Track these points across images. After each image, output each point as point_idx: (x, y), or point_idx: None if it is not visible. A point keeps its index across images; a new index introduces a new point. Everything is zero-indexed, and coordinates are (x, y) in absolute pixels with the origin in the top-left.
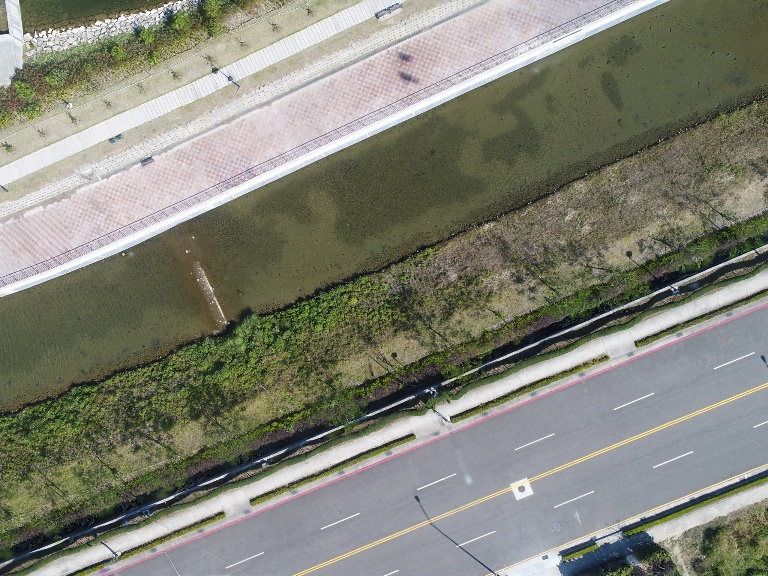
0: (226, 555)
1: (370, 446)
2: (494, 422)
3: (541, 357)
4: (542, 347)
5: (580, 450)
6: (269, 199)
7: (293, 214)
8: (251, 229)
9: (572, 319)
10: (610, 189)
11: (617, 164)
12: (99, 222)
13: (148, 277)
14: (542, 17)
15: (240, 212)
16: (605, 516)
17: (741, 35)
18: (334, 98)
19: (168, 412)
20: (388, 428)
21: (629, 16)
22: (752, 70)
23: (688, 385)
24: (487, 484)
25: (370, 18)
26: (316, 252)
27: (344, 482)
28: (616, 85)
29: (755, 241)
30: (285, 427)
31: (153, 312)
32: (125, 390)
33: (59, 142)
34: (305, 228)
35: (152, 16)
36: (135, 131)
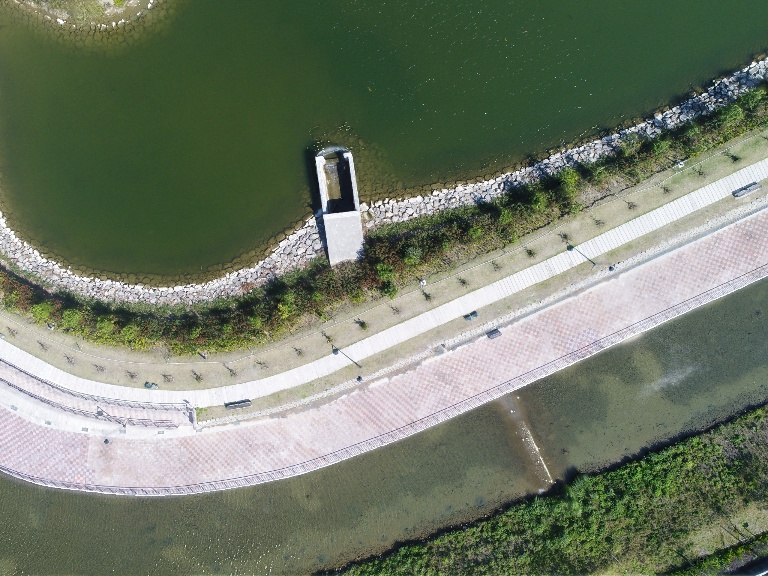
0: None
1: None
2: None
3: None
4: None
5: None
6: (593, 359)
7: (618, 374)
8: (575, 389)
9: None
10: None
11: None
12: (445, 393)
13: (471, 436)
14: None
15: (564, 372)
16: None
17: None
18: (682, 271)
19: None
20: None
21: None
22: None
23: None
24: None
25: (727, 196)
26: (641, 411)
27: None
28: None
29: None
30: None
31: (476, 471)
32: (458, 552)
33: (413, 319)
34: (630, 388)
35: (492, 187)
36: (490, 308)
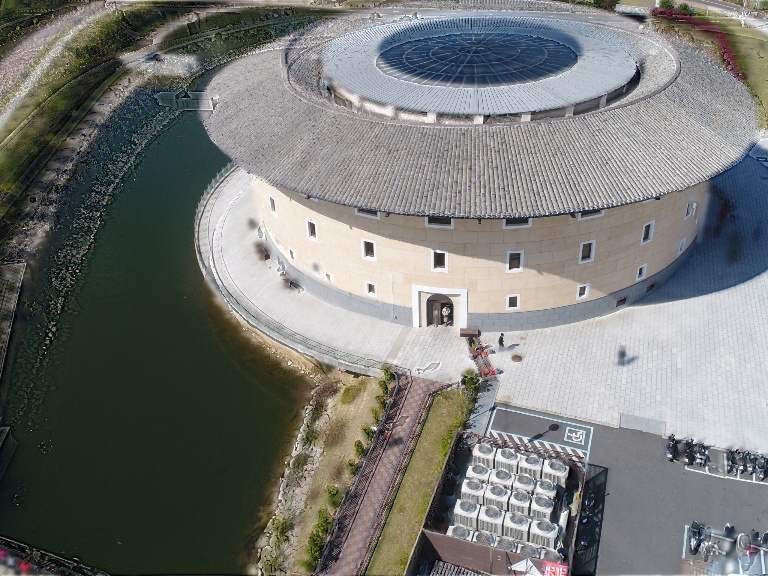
0: None
1: None
2: None
3: None
4: None
5: None
6: None
7: None
8: None
9: None
10: None
11: None
12: None
13: None
14: None
15: None
16: None
17: None
18: None
19: None
20: None
21: None
22: None
23: None
24: None
25: (10, 190)
26: None
27: None
28: None
29: None
30: None
31: None
32: None
33: None
34: None
35: None
36: None
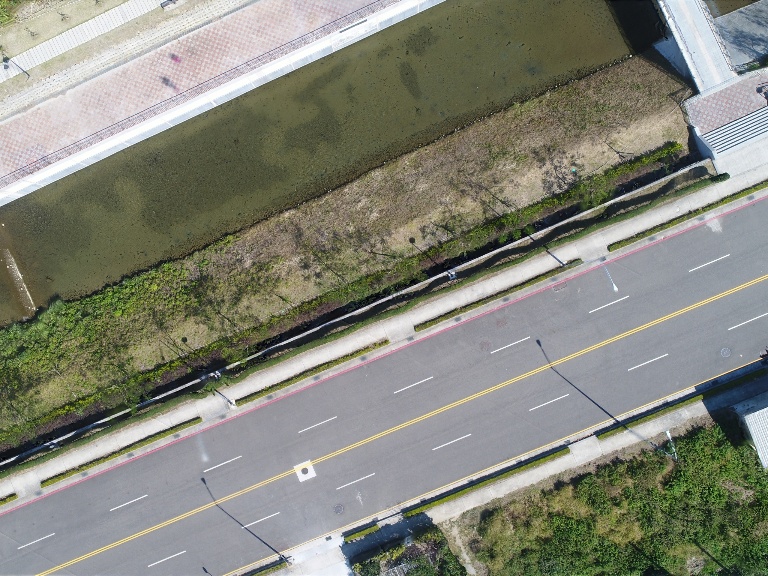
0: (18, 536)
1: (158, 429)
2: (278, 405)
3: (319, 341)
4: (324, 331)
5: (361, 433)
6: (77, 187)
7: (101, 202)
8: (60, 217)
9: (357, 304)
10: (403, 177)
11: (413, 153)
12: None
13: None
14: (328, 7)
15: (49, 200)
16: (386, 498)
17: (536, 26)
18: (126, 87)
19: None
20: (175, 411)
21: (424, 7)
22: (546, 60)
23: (466, 369)
24: (271, 466)
25: (156, 8)
26: (123, 239)
27: (133, 464)
28: (414, 75)
29: (525, 227)
30: (75, 410)
31: None
32: None
33: None
34: (112, 216)
35: None
36: None
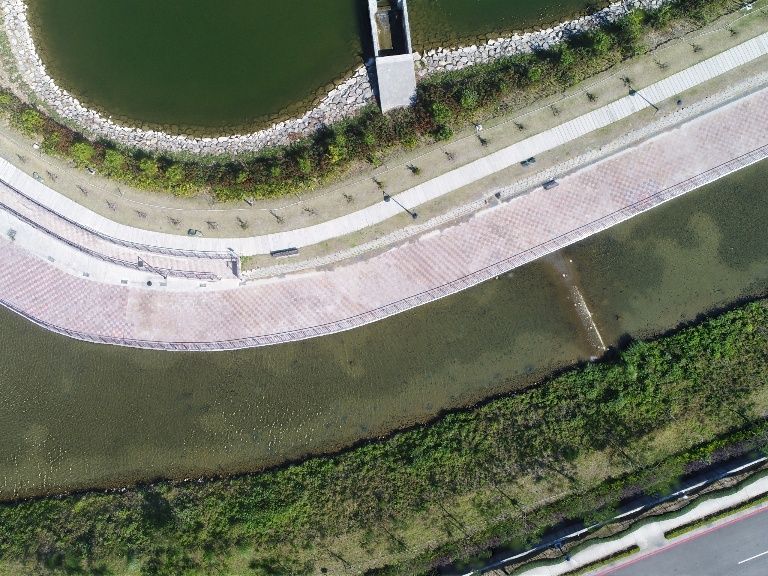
0: None
1: None
2: None
3: None
4: None
5: None
6: (649, 222)
7: (674, 238)
8: (630, 253)
9: None
10: None
11: None
12: (499, 246)
13: (521, 301)
14: None
15: (619, 235)
16: None
17: None
18: (747, 121)
19: (565, 441)
20: None
21: None
22: None
23: None
24: None
25: None
26: (698, 277)
27: (762, 515)
28: None
29: None
30: (702, 458)
31: (526, 337)
32: (507, 418)
33: (468, 165)
34: (687, 252)
35: (550, 35)
36: (548, 154)
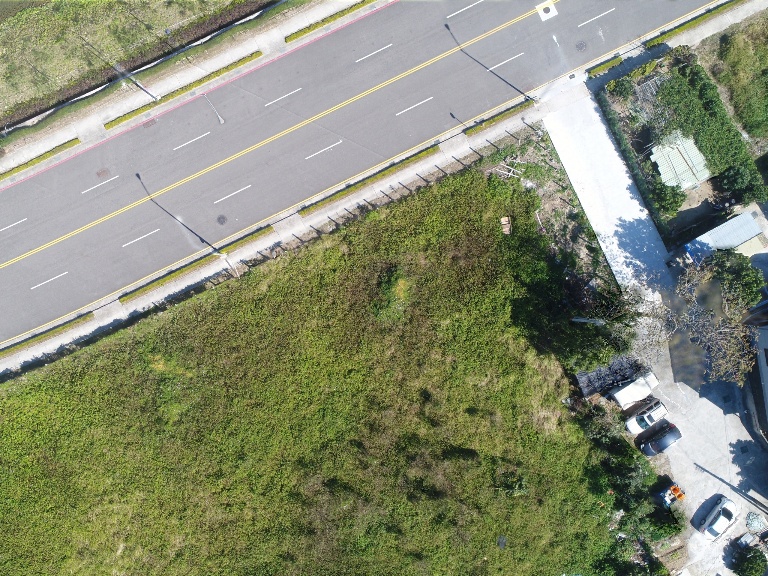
0: (264, 93)
1: None
2: None
3: None
4: None
5: None
6: None
7: None
8: None
9: None
10: None
11: None
12: None
13: None
14: None
15: None
16: (627, 32)
17: None
18: None
19: None
20: None
21: None
22: None
23: None
24: (513, 8)
25: None
26: None
27: (376, 16)
28: None
29: None
30: None
31: None
32: None
33: None
34: None
35: None
36: None
